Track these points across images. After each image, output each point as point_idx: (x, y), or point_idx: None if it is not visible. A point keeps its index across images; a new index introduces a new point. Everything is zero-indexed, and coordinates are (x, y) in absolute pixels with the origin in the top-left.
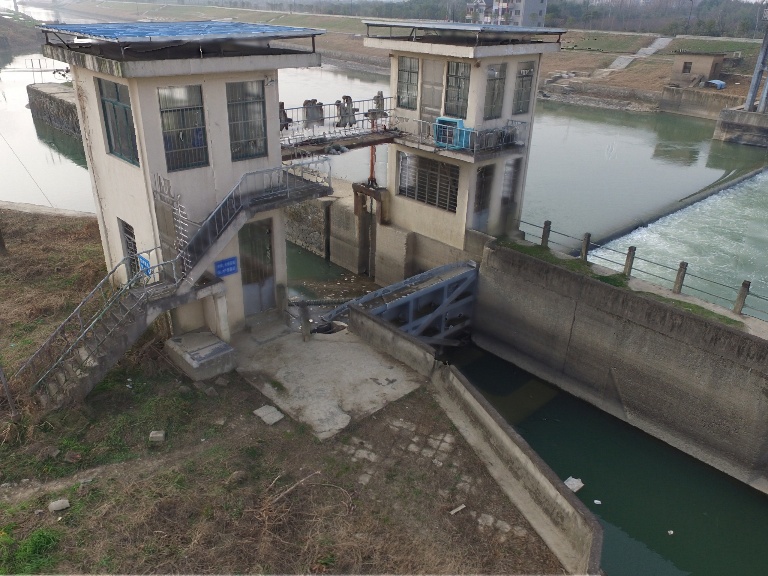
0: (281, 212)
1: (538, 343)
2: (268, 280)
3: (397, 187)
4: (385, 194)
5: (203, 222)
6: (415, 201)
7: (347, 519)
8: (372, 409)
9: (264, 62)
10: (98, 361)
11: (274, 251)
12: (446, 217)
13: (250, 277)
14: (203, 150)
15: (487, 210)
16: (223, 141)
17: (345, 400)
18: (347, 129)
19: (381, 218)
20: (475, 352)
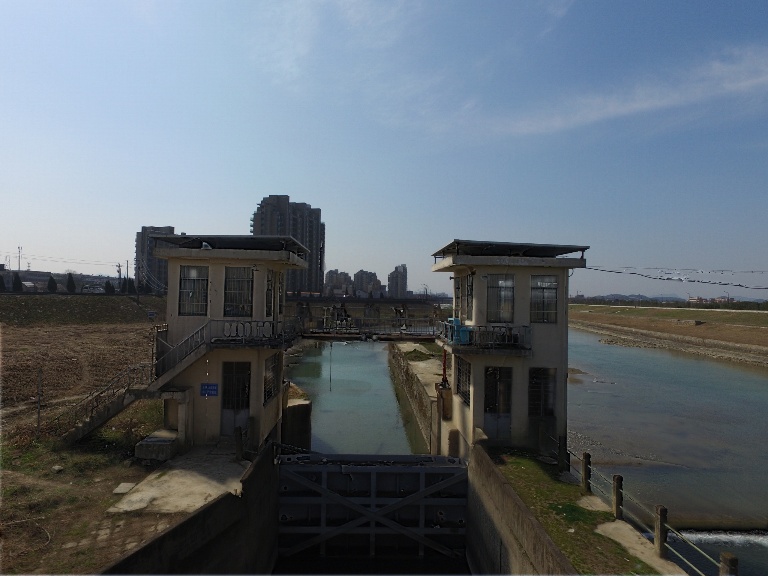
0: (259, 360)
1: (487, 570)
2: (244, 411)
3: (456, 387)
4: (447, 392)
5: (175, 346)
6: (459, 399)
7: (5, 557)
8: (166, 510)
9: (244, 254)
10: (89, 419)
11: (250, 388)
12: (466, 414)
13: (230, 404)
14: (204, 306)
15: (509, 415)
16: (219, 302)
17: (167, 497)
18: (402, 329)
19: (443, 414)
20: (461, 570)
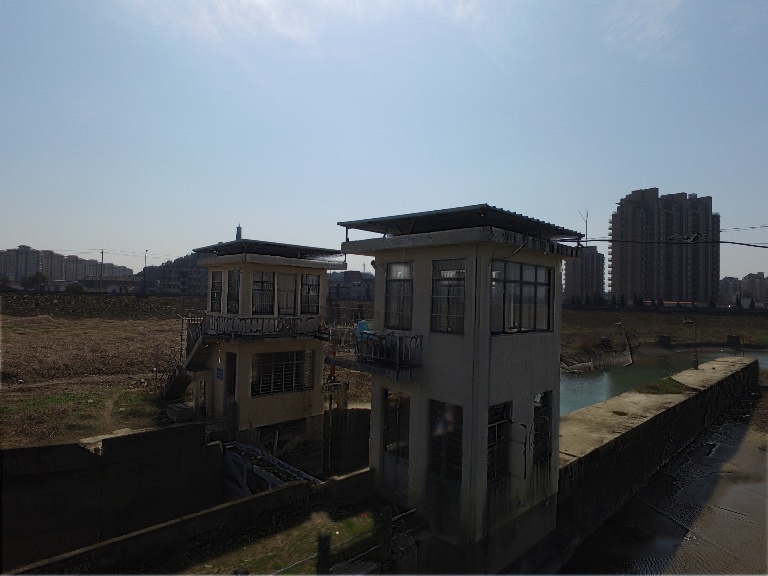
0: None
1: None
2: (234, 396)
3: None
4: None
5: None
6: None
7: None
8: (91, 448)
9: (227, 259)
10: None
11: None
12: None
13: None
14: None
15: None
16: None
17: None
18: None
19: None
20: None
